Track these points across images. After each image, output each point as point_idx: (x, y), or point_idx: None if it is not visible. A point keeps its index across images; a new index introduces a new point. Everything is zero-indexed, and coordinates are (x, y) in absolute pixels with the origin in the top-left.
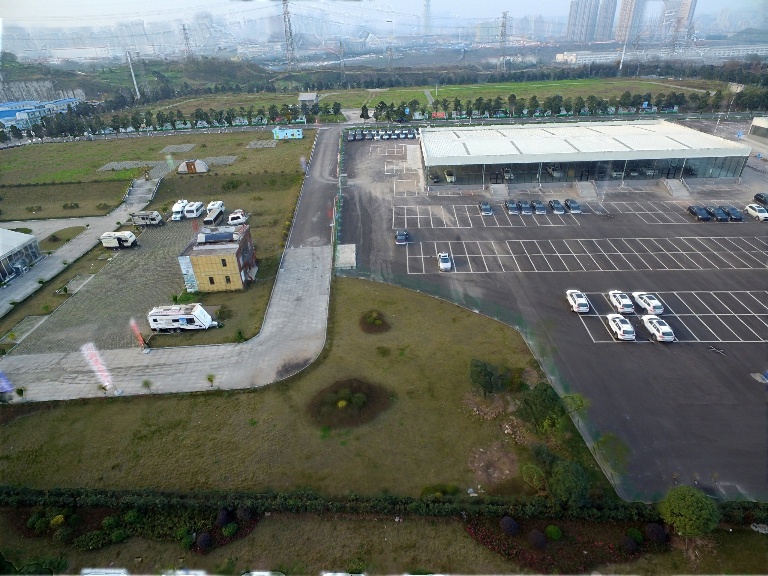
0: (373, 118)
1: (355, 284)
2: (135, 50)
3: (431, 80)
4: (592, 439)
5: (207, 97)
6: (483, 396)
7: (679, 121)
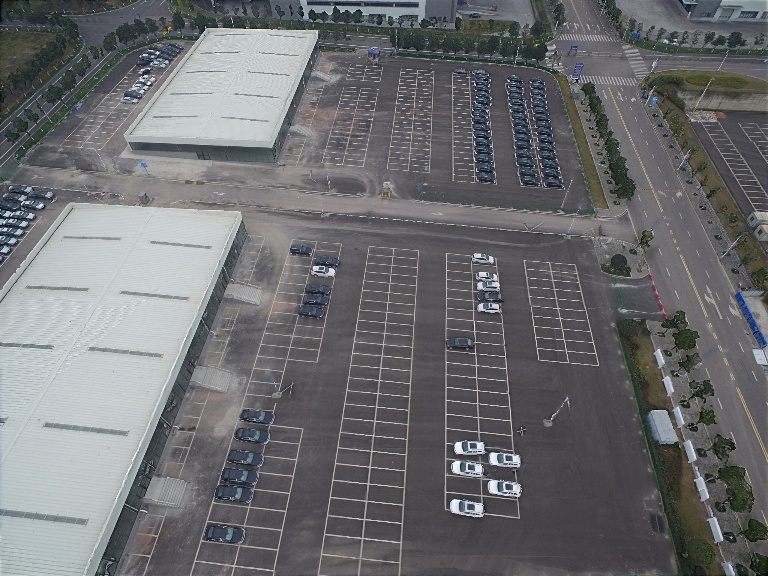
0: None
1: None
2: None
3: None
4: (628, 573)
5: None
6: None
7: (28, 161)
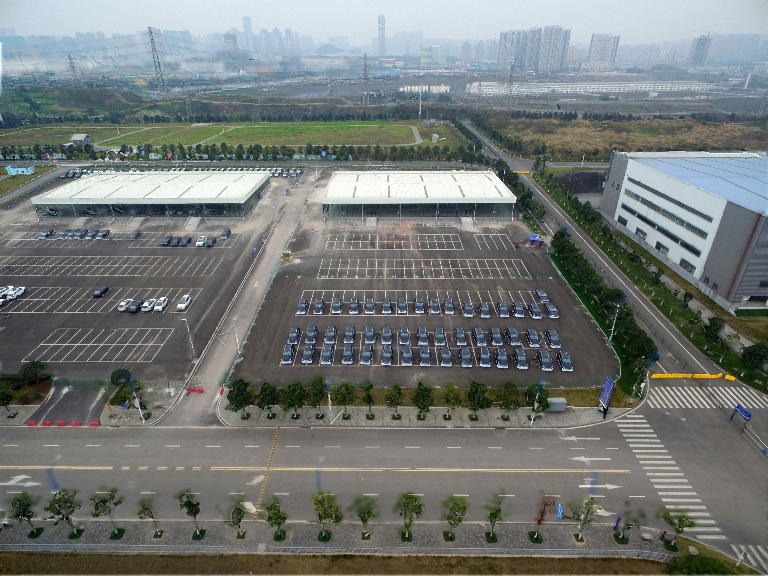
0: None
1: None
2: (15, 78)
3: (253, 117)
4: None
5: (49, 126)
6: None
7: (325, 169)
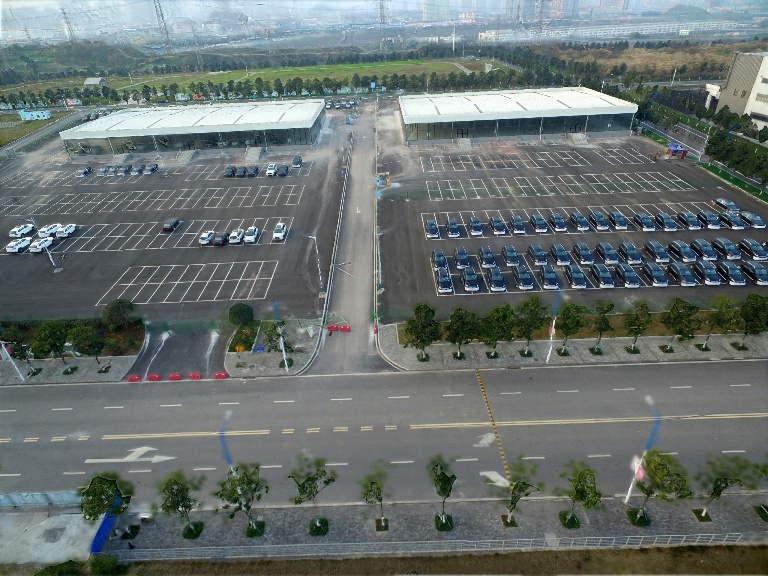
0: (145, 100)
1: None
2: (8, 35)
3: (273, 63)
4: None
5: (53, 81)
6: None
7: (380, 99)
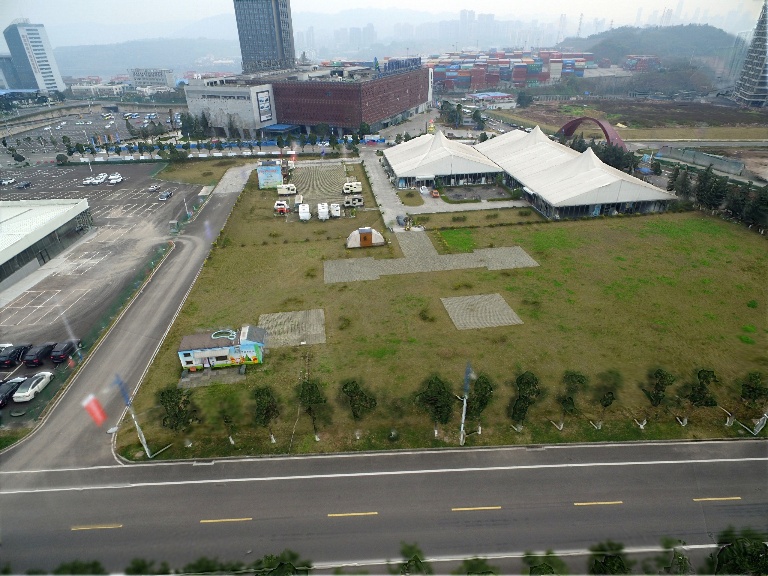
0: None
1: (208, 182)
2: None
3: None
4: None
5: None
6: (184, 168)
7: None
